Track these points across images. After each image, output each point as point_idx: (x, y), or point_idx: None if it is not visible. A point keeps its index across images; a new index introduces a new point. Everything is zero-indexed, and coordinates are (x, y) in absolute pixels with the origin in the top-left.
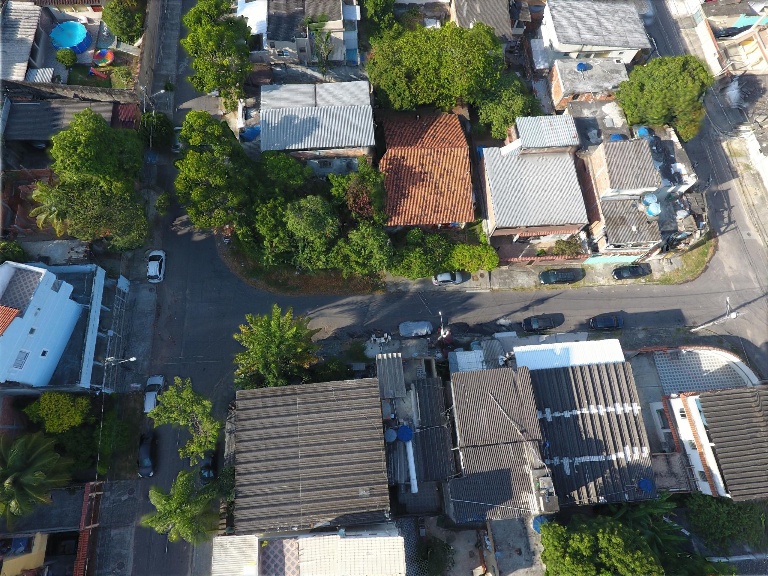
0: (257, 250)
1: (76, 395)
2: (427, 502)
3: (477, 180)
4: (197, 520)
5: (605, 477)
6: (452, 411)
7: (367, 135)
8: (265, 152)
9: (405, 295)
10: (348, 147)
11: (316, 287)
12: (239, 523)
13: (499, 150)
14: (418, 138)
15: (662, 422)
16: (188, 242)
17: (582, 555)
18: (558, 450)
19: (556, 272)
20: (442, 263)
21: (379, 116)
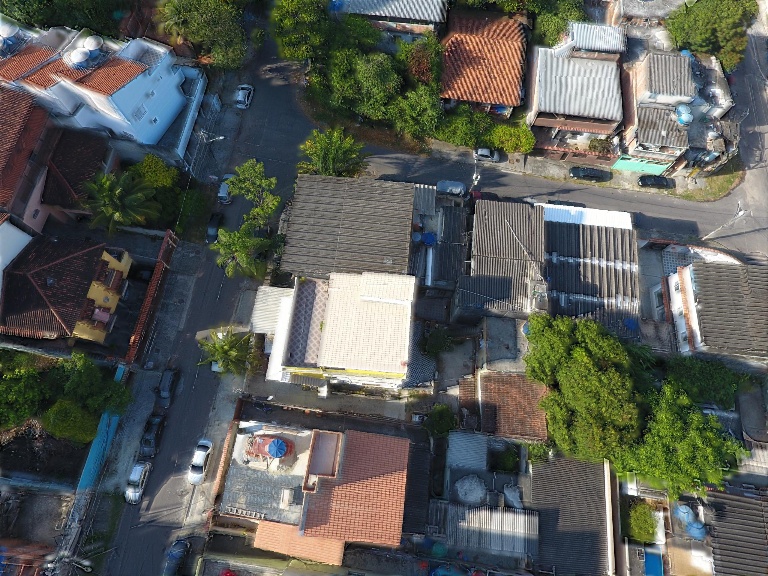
0: (330, 96)
1: (171, 165)
2: (435, 316)
3: (529, 81)
4: (251, 258)
5: (594, 313)
6: (471, 234)
7: (440, 14)
8: (352, 14)
9: (447, 162)
10: (422, 23)
11: (372, 139)
12: (284, 263)
13: (553, 51)
14: (483, 31)
15: (658, 303)
16: (273, 84)
17: (559, 330)
18: (557, 285)
19: (586, 168)
20: (485, 136)
21: (452, 13)
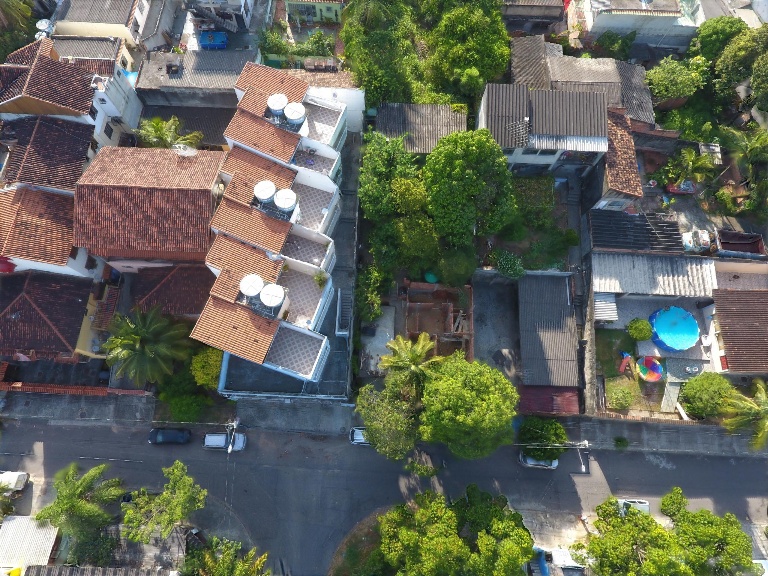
0: (372, 569)
1: None
2: None
3: None
4: None
5: None
6: None
7: None
8: None
9: None
10: None
11: None
12: (36, 572)
13: None
14: None
15: None
16: (397, 471)
17: None
18: None
19: None
20: None
21: None
